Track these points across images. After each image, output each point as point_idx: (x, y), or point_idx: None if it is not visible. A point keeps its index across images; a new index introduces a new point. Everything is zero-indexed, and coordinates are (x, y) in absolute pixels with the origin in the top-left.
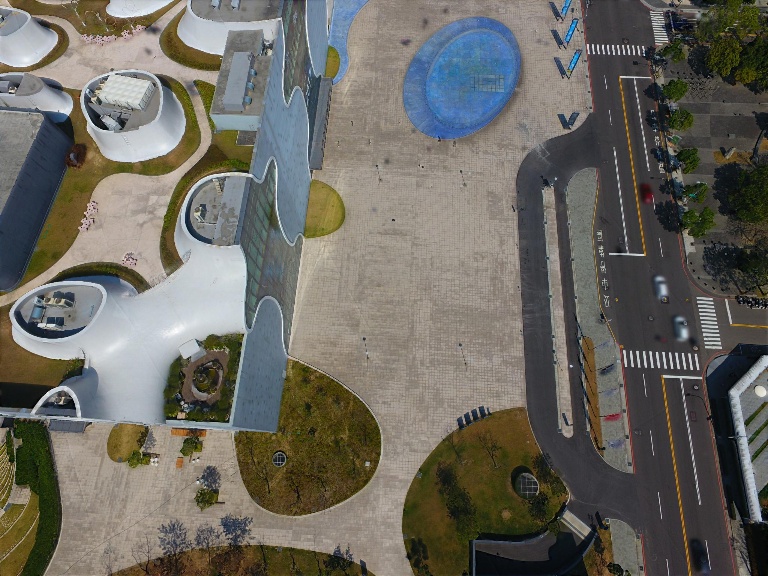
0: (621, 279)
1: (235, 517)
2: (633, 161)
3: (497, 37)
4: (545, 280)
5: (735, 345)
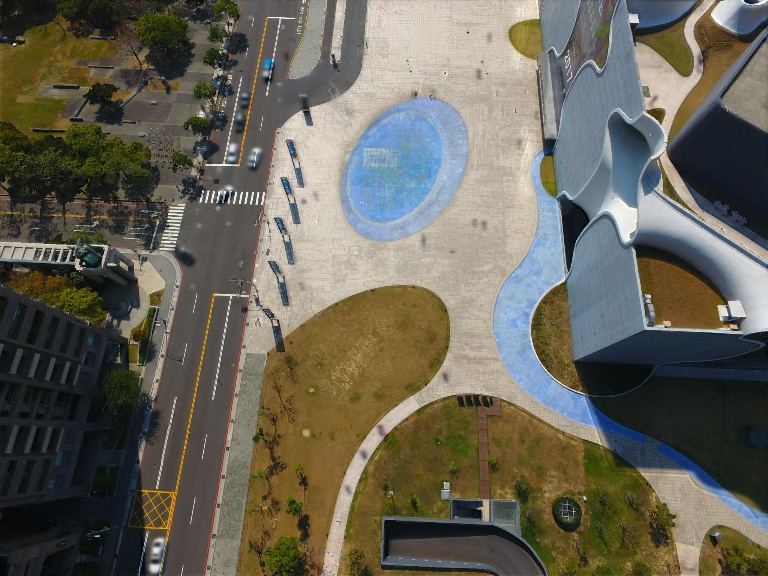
0: (291, 3)
1: None
2: (253, 84)
3: (364, 214)
4: (349, 0)
5: None
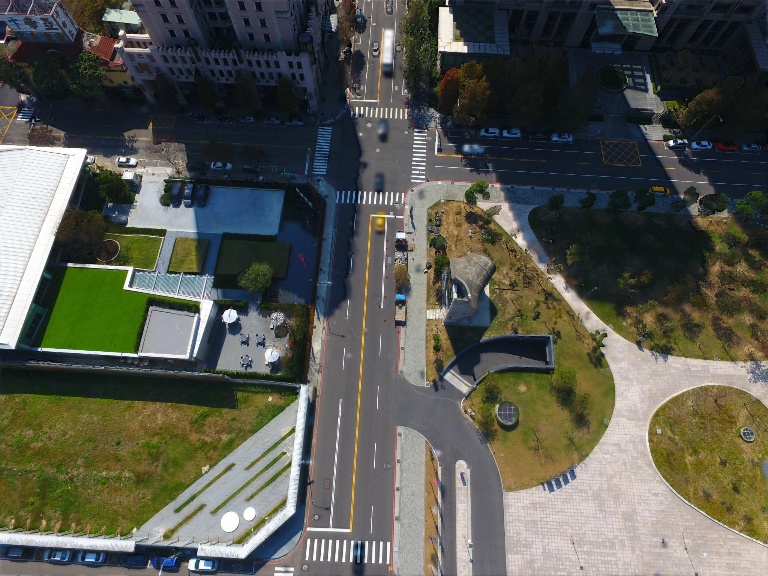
0: None
1: (766, 383)
2: None
3: None
4: None
5: (259, 573)
